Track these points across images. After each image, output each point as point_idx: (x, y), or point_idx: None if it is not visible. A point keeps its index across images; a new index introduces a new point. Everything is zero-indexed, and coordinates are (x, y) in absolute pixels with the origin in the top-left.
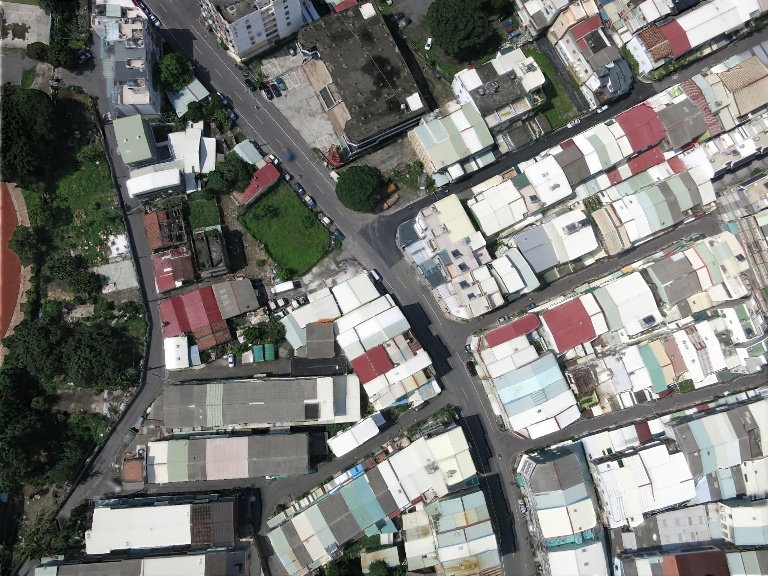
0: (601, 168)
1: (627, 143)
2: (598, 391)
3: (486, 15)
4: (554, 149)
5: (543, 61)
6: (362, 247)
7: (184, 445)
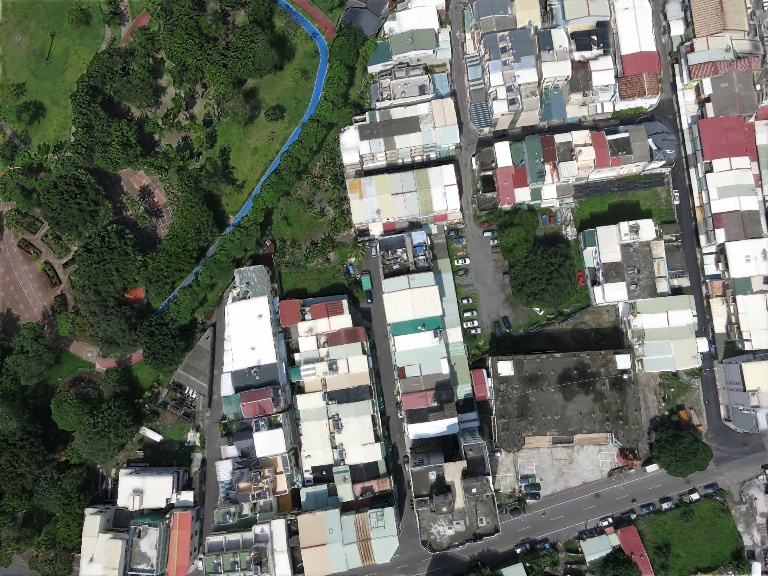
0: (756, 197)
1: (738, 159)
2: None
3: None
4: (717, 236)
5: (596, 200)
6: (733, 469)
7: None
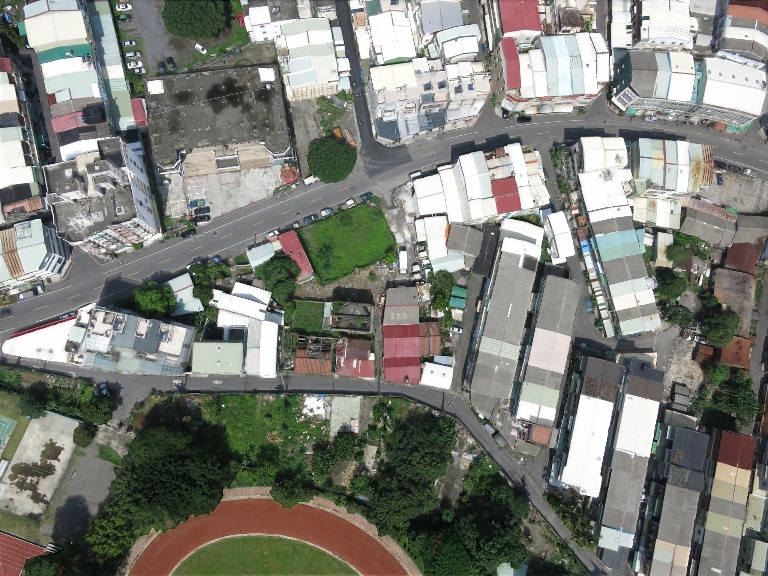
0: None
1: None
2: (581, 13)
3: None
4: None
5: None
6: (385, 179)
7: (528, 386)
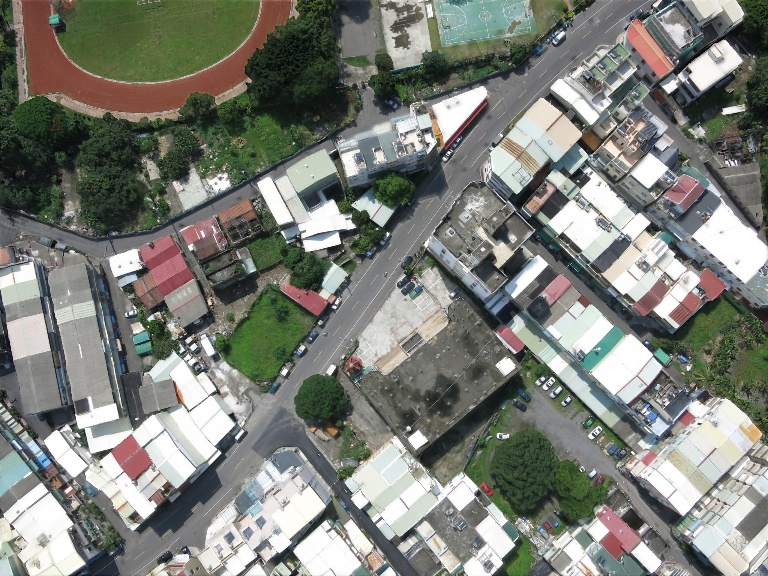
0: None
1: None
2: None
3: (551, 496)
4: None
5: (522, 572)
6: (267, 414)
7: (35, 294)
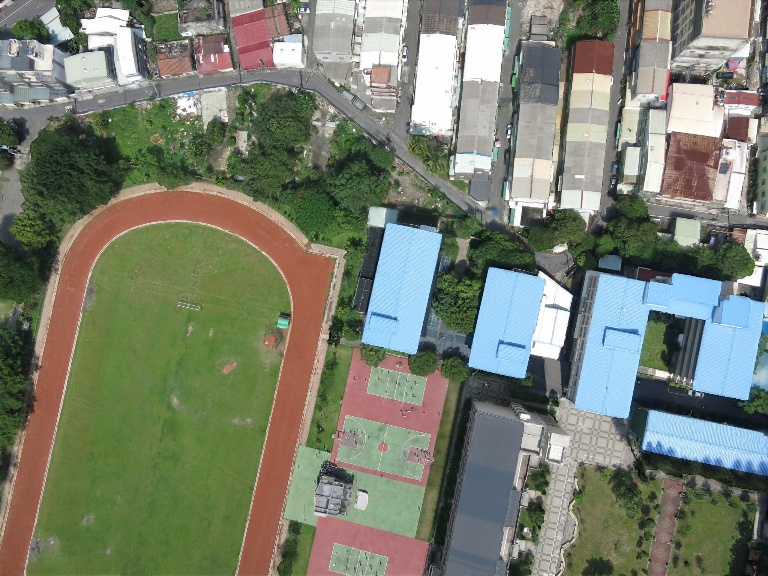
0: None
1: None
2: None
3: None
4: None
5: None
6: None
7: (367, 37)
